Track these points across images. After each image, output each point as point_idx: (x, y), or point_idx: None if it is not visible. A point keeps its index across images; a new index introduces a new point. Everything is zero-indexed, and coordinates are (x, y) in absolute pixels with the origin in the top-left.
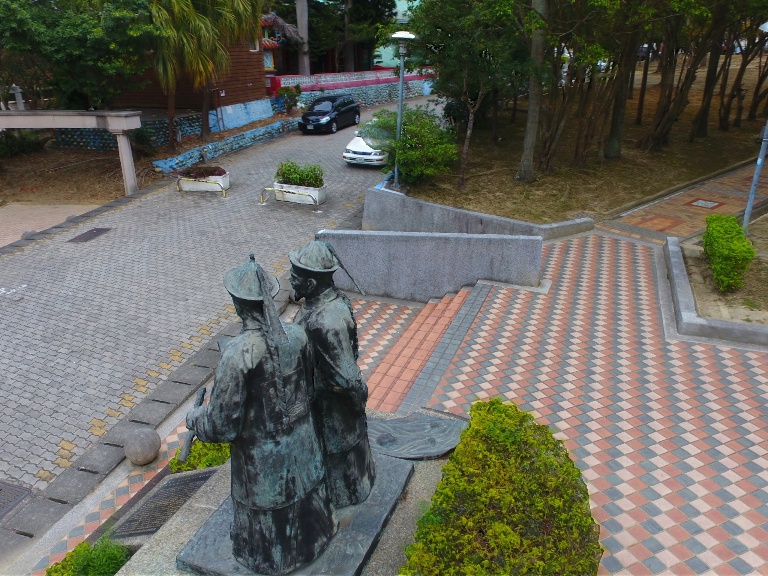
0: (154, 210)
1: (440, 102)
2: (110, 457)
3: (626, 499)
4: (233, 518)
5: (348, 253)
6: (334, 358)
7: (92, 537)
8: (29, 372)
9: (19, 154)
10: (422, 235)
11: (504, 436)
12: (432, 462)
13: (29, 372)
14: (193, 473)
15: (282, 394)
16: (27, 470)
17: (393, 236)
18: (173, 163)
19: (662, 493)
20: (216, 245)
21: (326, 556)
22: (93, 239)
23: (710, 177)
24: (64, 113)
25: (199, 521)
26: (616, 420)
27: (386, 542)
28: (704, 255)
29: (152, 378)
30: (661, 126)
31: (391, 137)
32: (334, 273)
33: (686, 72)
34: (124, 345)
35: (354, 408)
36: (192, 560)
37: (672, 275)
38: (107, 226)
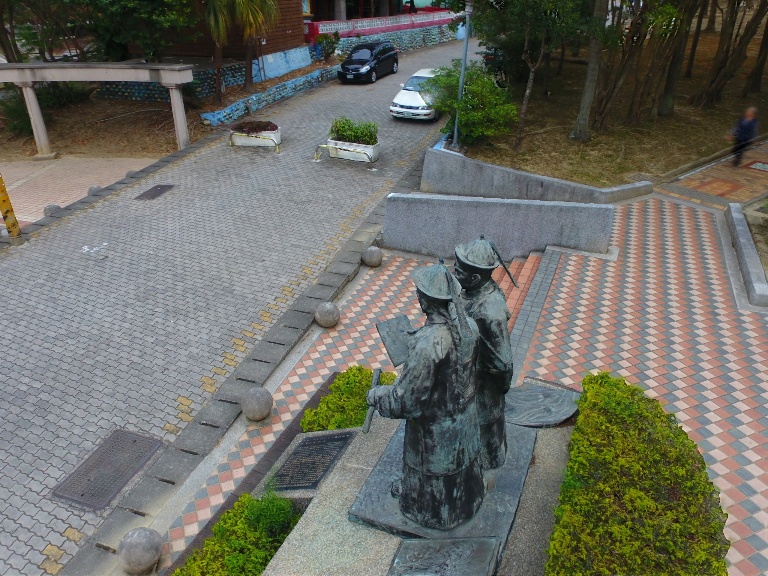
0: (211, 166)
1: (488, 54)
2: (227, 413)
3: (720, 464)
4: (389, 478)
5: (417, 217)
6: (495, 345)
7: (241, 487)
8: (133, 330)
9: (67, 105)
10: (493, 201)
11: (620, 409)
12: (551, 430)
13: (133, 330)
14: (327, 433)
15: (462, 379)
16: (154, 423)
17: (463, 201)
18: (221, 116)
19: (753, 459)
20: (280, 204)
21: (481, 514)
22: (159, 196)
23: (766, 137)
24: (117, 66)
25: (355, 479)
26: (701, 389)
27: (526, 502)
28: (767, 223)
29: (248, 338)
30: (716, 82)
31: (452, 97)
32: (402, 235)
33: (745, 25)
34: (214, 305)
35: (504, 387)
36: (364, 514)
37: (739, 244)
38: (169, 183)
